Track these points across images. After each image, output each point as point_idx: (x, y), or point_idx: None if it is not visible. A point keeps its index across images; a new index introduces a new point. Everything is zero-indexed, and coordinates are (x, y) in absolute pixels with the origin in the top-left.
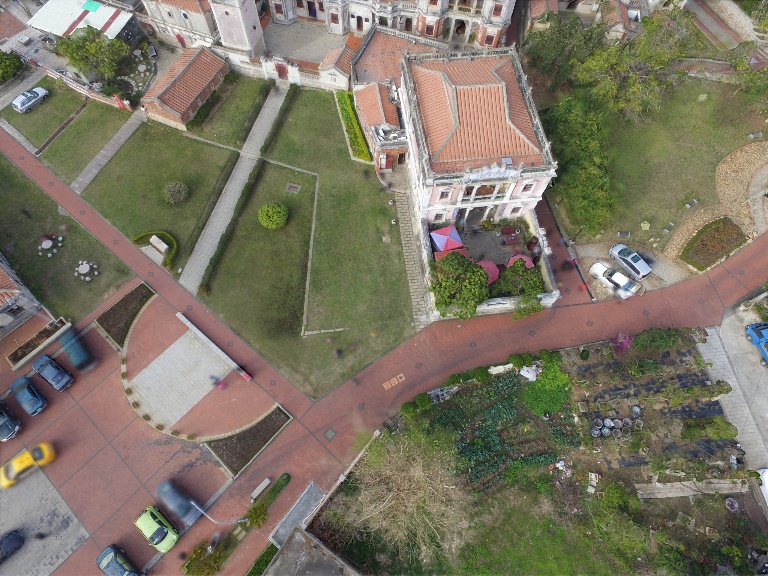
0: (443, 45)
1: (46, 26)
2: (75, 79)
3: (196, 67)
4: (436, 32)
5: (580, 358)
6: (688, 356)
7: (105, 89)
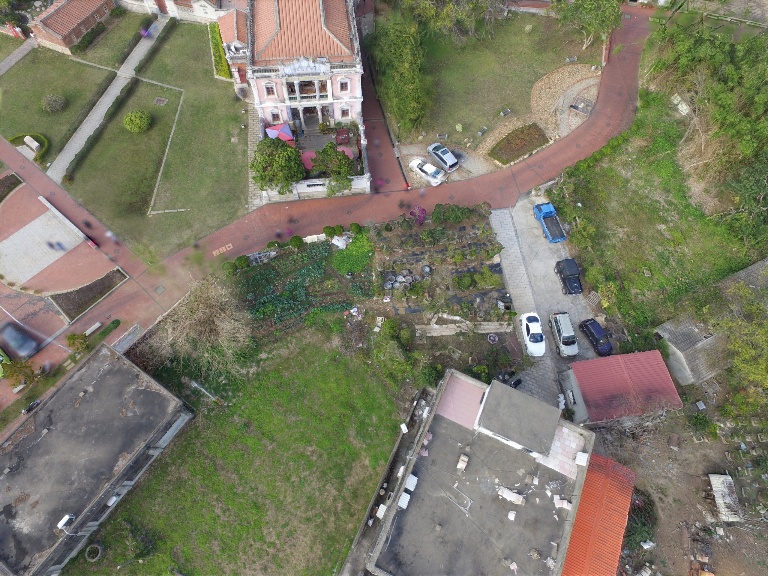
0: None
1: None
2: None
3: None
4: None
5: None
6: (481, 230)
7: (0, 19)
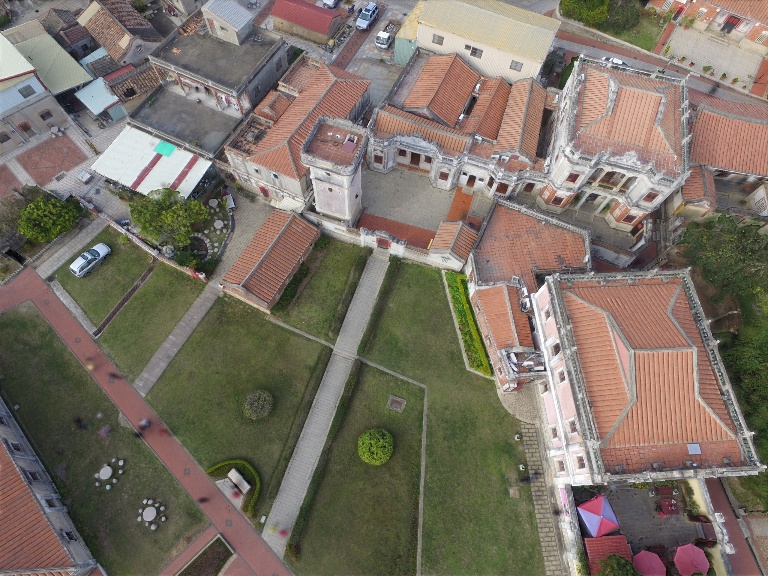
0: (579, 230)
1: (113, 173)
2: (142, 237)
3: (285, 240)
4: (565, 204)
5: None
6: None
7: (177, 255)
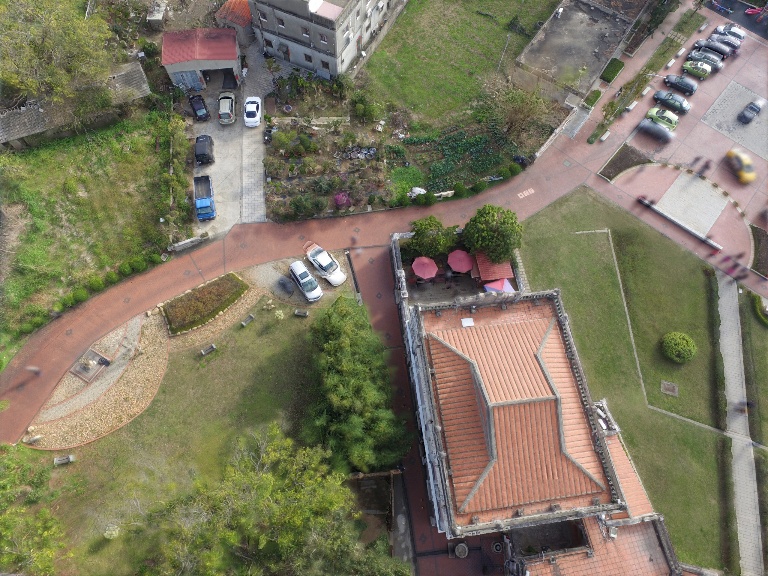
0: None
1: None
2: None
3: None
4: None
5: None
6: None
7: None
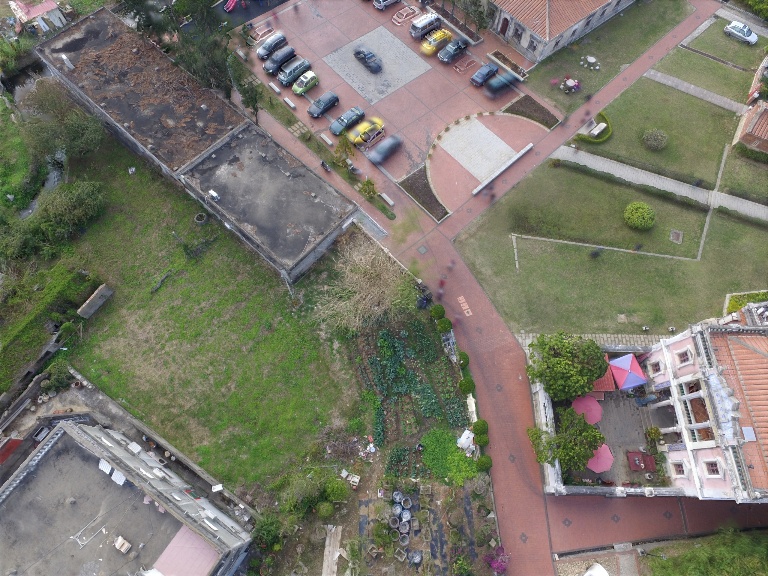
0: None
1: None
2: None
3: None
4: None
5: None
6: None
7: None
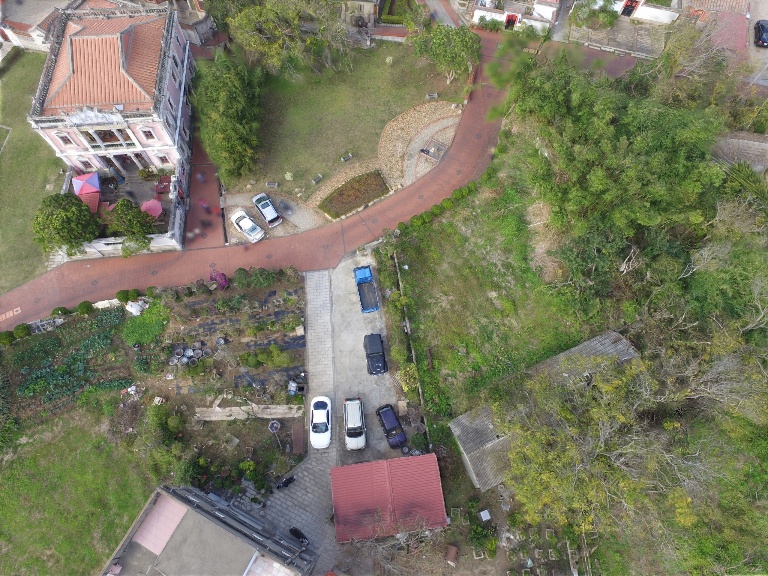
0: None
1: None
2: None
3: None
4: None
5: (184, 294)
6: (293, 295)
7: None
